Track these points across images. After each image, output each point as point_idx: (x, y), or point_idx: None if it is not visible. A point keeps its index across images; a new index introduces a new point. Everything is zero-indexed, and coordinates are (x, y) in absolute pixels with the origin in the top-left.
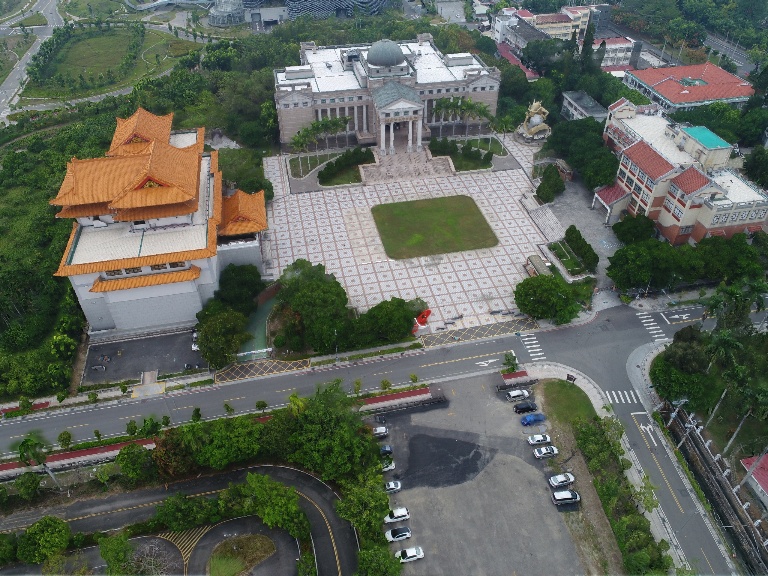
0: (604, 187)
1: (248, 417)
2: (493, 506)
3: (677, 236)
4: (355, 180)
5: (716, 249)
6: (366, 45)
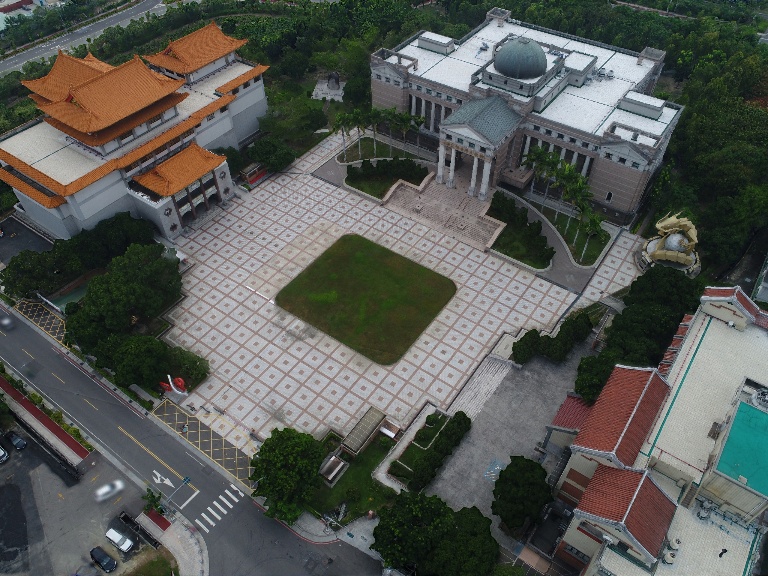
0: (581, 396)
1: None
2: None
3: (561, 549)
4: (378, 194)
5: None
6: (571, 38)
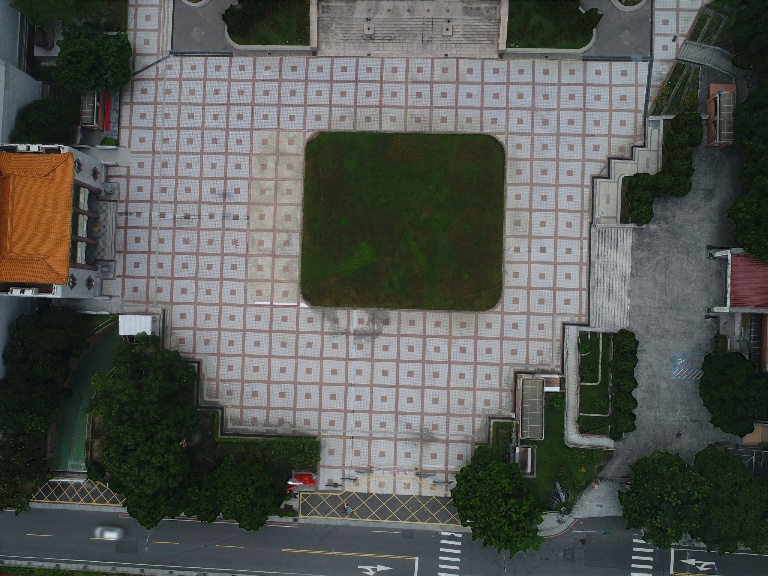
0: None
1: (51, 575)
2: None
3: None
4: (297, 38)
5: None
6: None
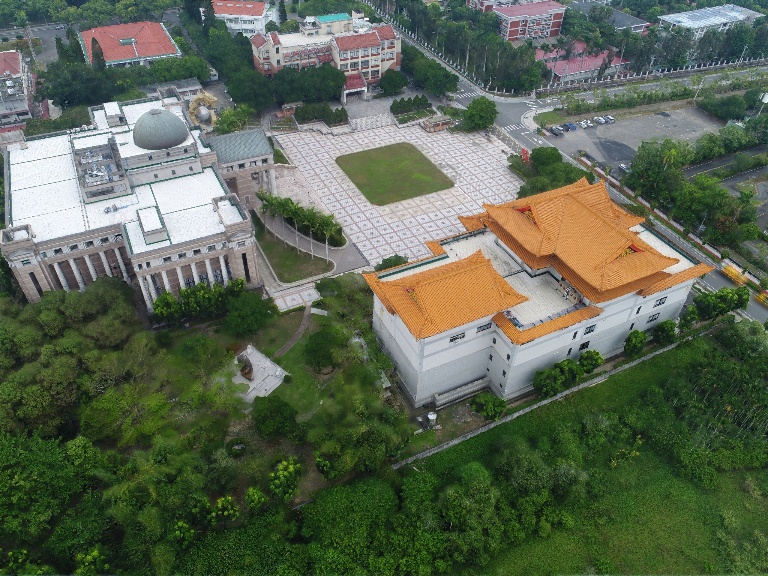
0: None
1: None
2: (630, 136)
3: None
4: None
5: None
6: (8, 191)
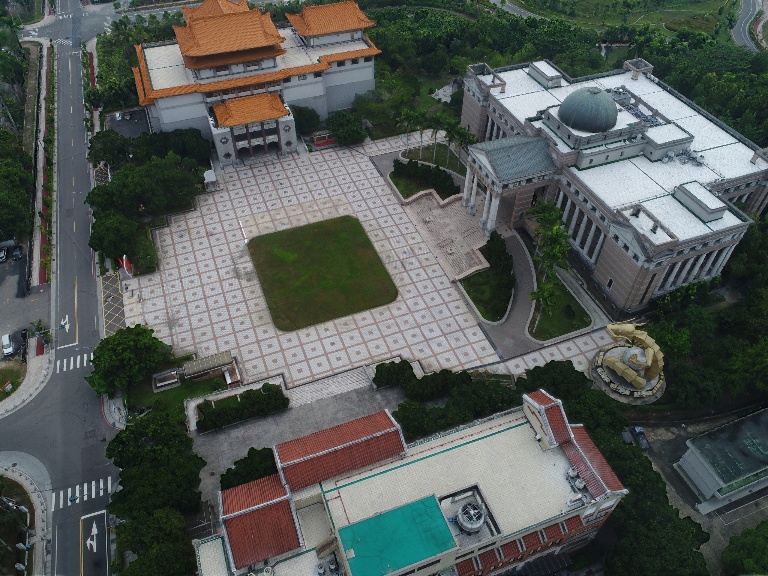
0: None
1: None
2: None
3: None
4: (406, 194)
5: (150, 568)
6: (701, 112)
